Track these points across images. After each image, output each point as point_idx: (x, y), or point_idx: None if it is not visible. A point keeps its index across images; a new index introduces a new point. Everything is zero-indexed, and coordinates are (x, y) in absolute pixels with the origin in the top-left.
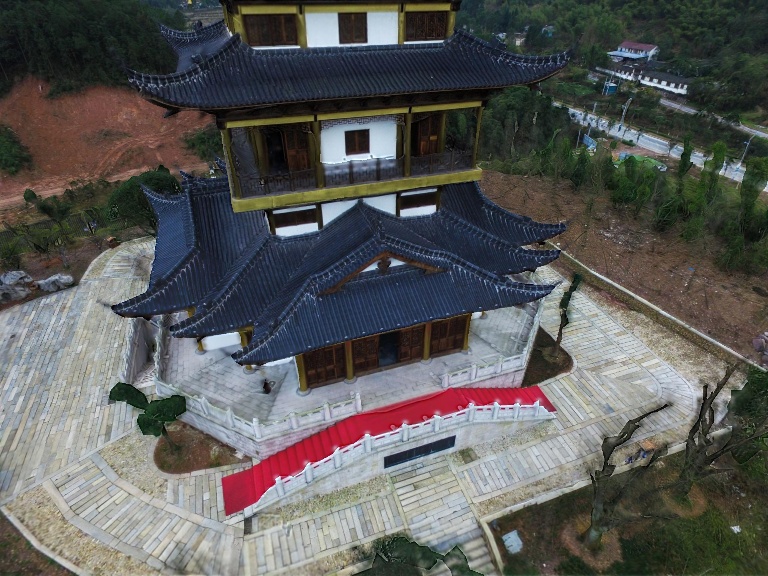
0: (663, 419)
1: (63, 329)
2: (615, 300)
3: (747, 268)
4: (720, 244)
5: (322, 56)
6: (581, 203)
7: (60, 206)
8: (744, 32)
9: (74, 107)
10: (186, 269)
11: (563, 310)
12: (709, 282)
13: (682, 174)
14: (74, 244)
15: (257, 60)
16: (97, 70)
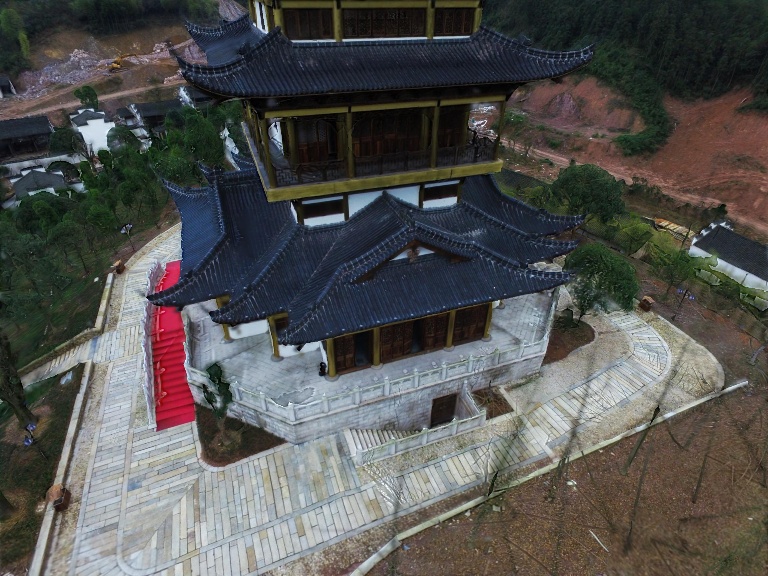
0: (89, 549)
1: None
2: None
3: None
4: None
5: (257, 36)
6: None
7: None
8: None
9: (750, 126)
10: None
11: None
12: None
13: None
14: None
15: None
16: None
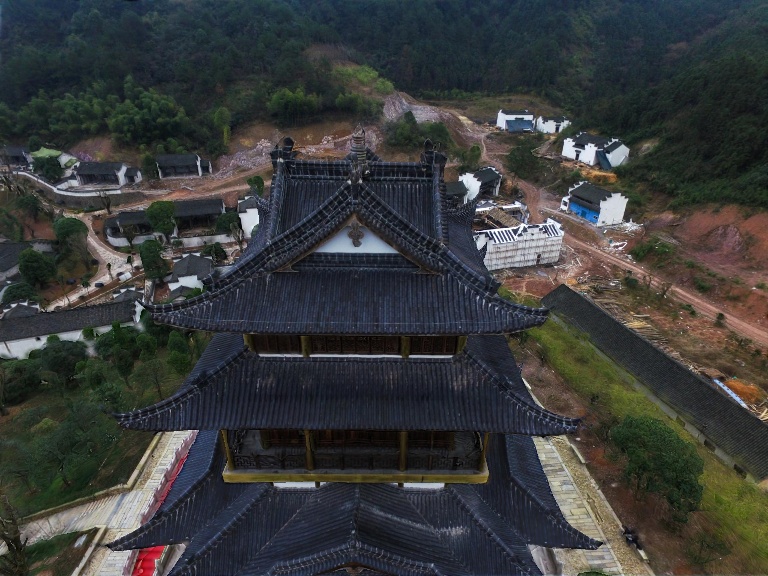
0: None
1: None
2: None
3: None
4: None
5: None
6: None
7: None
8: None
9: None
10: None
11: None
12: None
13: None
14: None
15: None
16: None
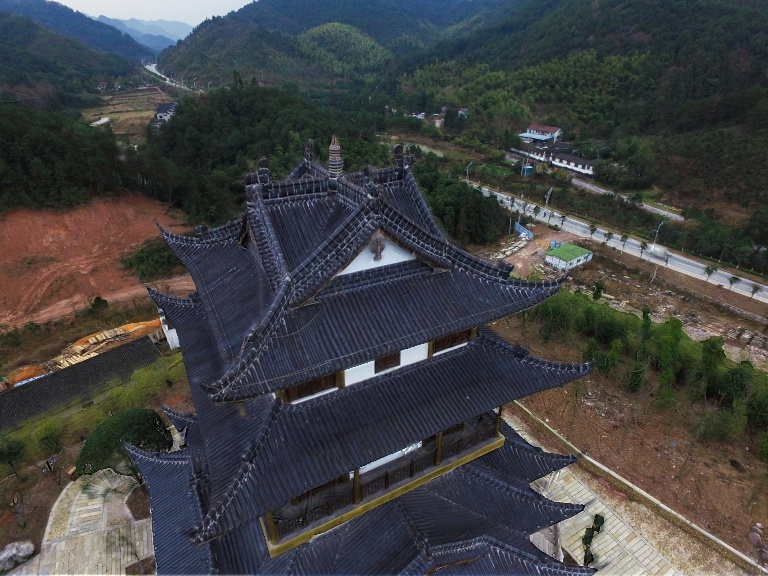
0: None
1: None
2: (614, 489)
3: (718, 436)
4: (686, 401)
5: (359, 390)
6: None
7: (12, 448)
8: (629, 116)
9: None
10: None
11: (587, 546)
12: (692, 460)
13: (645, 341)
14: (27, 482)
15: (298, 415)
16: (19, 194)
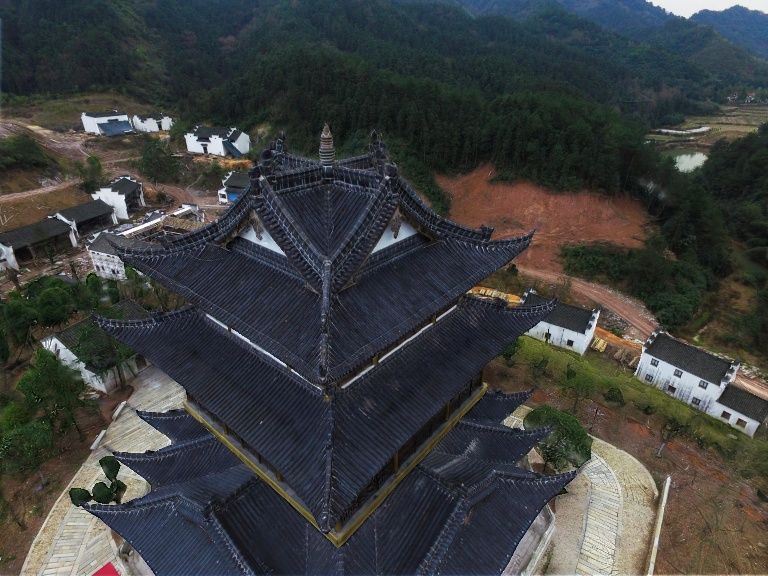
0: None
1: None
2: None
3: None
4: None
5: (237, 344)
6: None
7: None
8: None
9: (501, 193)
10: None
11: None
12: None
13: None
14: None
15: (204, 324)
16: (533, 170)
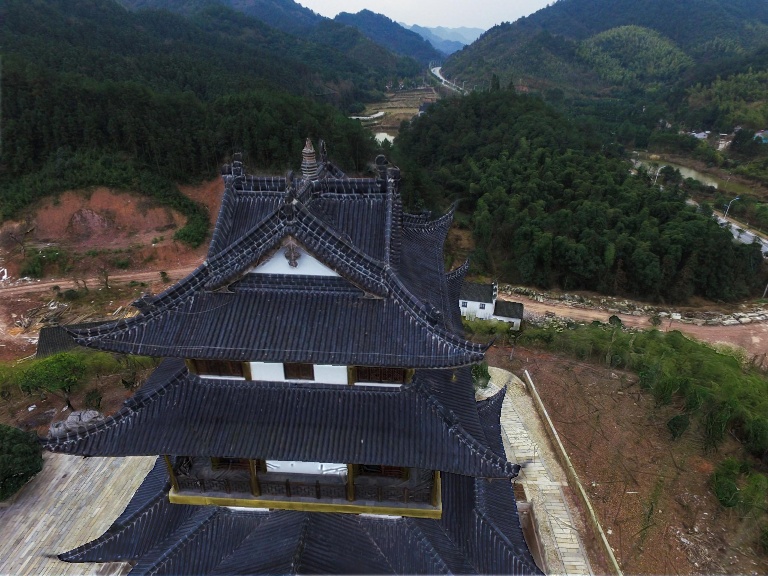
0: None
1: (99, 481)
2: None
3: None
4: None
5: (265, 389)
6: (671, 465)
7: None
8: None
9: None
10: (148, 512)
11: None
12: None
13: None
14: None
15: (201, 389)
16: (281, 166)
